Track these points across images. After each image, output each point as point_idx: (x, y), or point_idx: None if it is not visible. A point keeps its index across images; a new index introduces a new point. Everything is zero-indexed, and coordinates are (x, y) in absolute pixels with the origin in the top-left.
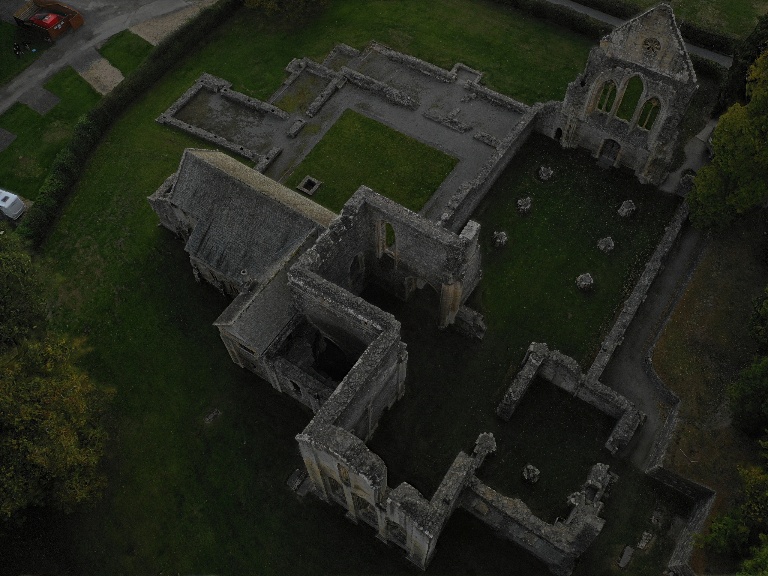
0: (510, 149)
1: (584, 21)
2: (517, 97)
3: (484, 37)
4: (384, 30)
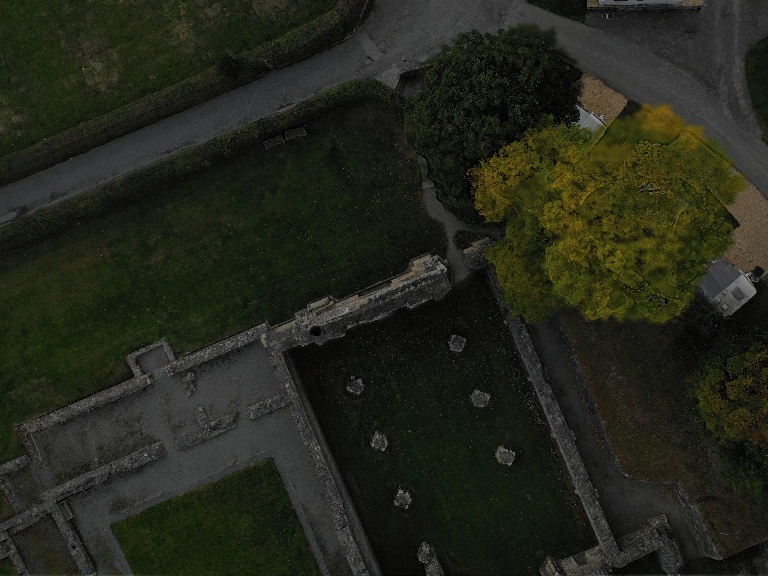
0: (311, 422)
1: (174, 171)
2: (228, 330)
3: (105, 294)
4: (7, 403)
